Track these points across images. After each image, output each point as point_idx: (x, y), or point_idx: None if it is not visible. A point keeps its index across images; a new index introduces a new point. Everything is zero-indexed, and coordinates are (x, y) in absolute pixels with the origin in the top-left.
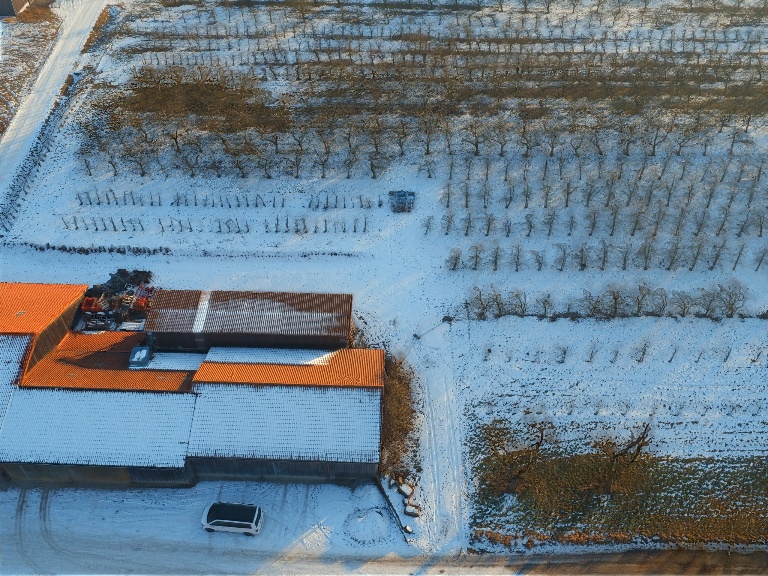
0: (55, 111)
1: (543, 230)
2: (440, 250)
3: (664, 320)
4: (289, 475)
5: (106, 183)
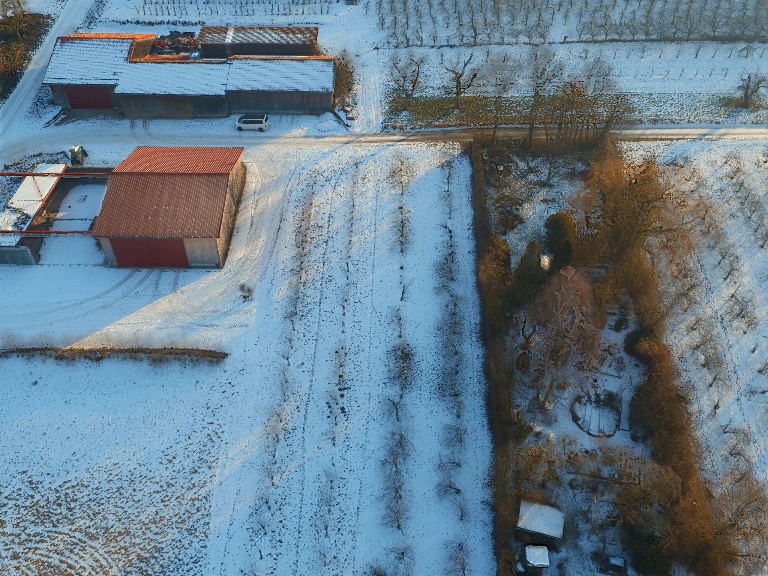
0: None
1: (439, 9)
2: (374, 21)
3: (505, 46)
4: (283, 110)
5: None
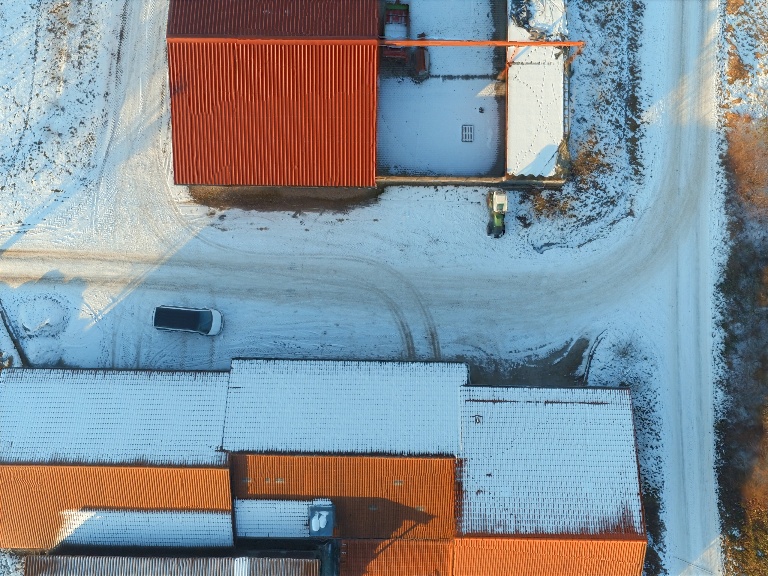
0: None
1: None
2: None
3: None
4: None
5: None
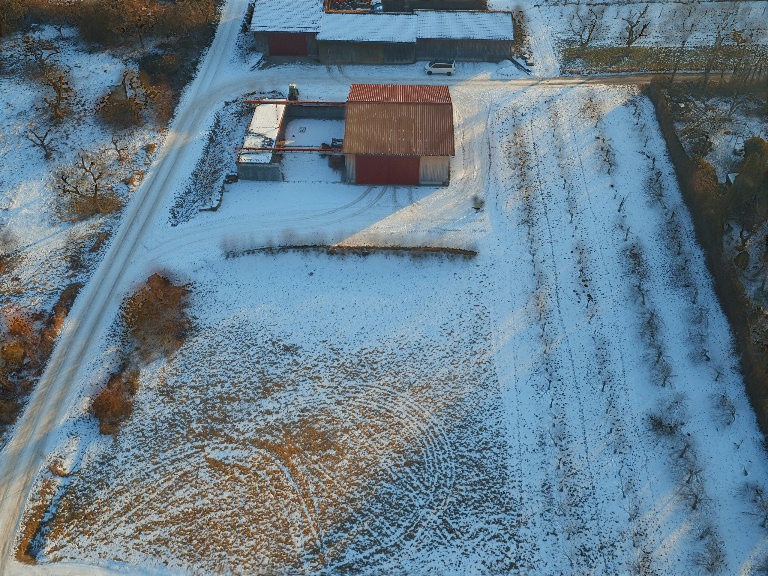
0: None
1: None
2: None
3: (656, 4)
4: (464, 58)
5: None
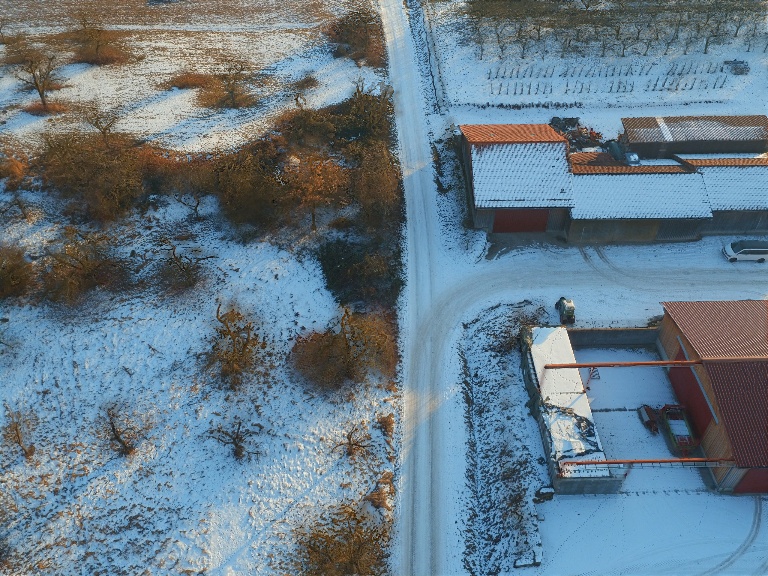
0: (411, 19)
1: None
2: None
3: None
4: (765, 230)
5: (498, 64)
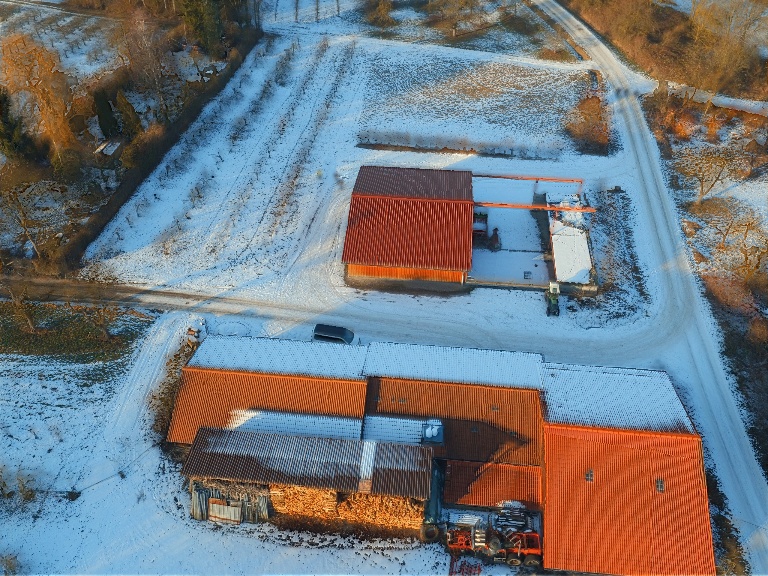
0: None
1: None
2: None
3: None
4: None
5: None
